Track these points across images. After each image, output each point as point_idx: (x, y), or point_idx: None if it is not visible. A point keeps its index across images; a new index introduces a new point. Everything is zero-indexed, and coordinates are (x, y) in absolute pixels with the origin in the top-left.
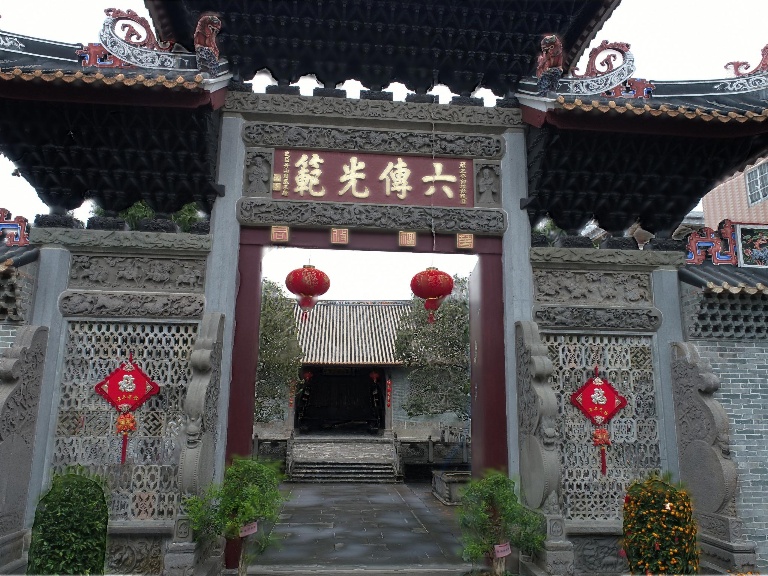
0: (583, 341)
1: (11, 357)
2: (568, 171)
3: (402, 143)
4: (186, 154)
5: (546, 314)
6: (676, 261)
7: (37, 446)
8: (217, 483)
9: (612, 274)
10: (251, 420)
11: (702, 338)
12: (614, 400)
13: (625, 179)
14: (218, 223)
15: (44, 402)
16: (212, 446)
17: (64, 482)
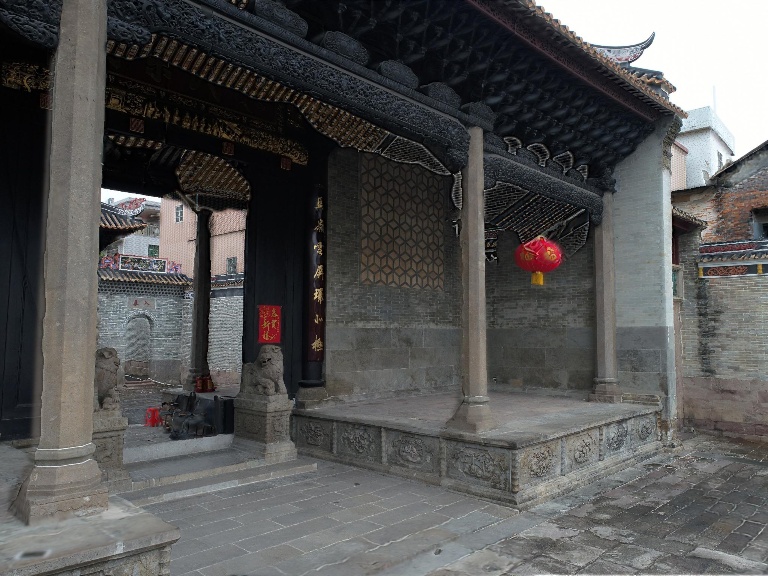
0: None
1: None
2: None
3: None
4: None
5: None
6: None
7: None
8: None
9: None
10: None
11: (101, 293)
12: None
13: None
14: None
15: None
16: None
17: None
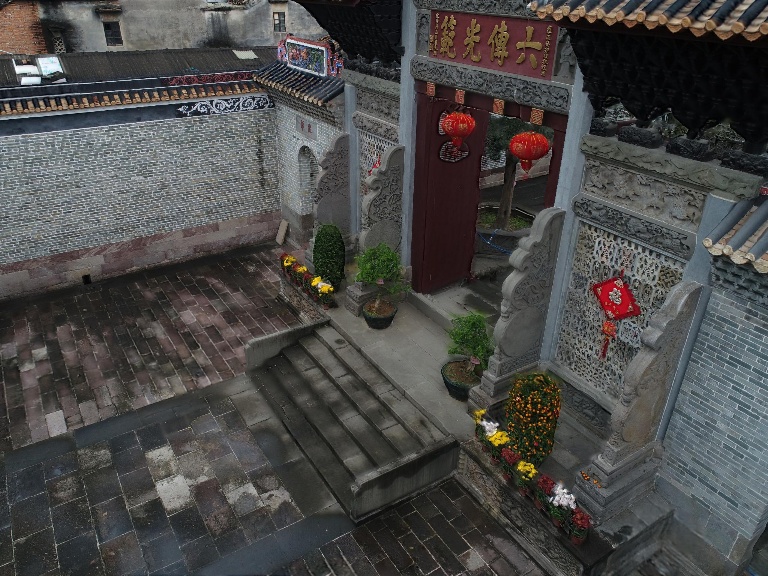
0: (619, 241)
1: (324, 156)
2: (608, 60)
3: (504, 4)
4: (375, 28)
5: (584, 206)
6: (736, 190)
7: (352, 196)
8: (405, 245)
9: (664, 182)
10: (460, 204)
11: (729, 290)
12: (628, 305)
13: (671, 76)
14: (402, 77)
15: (352, 175)
16: (395, 226)
17: (321, 230)
